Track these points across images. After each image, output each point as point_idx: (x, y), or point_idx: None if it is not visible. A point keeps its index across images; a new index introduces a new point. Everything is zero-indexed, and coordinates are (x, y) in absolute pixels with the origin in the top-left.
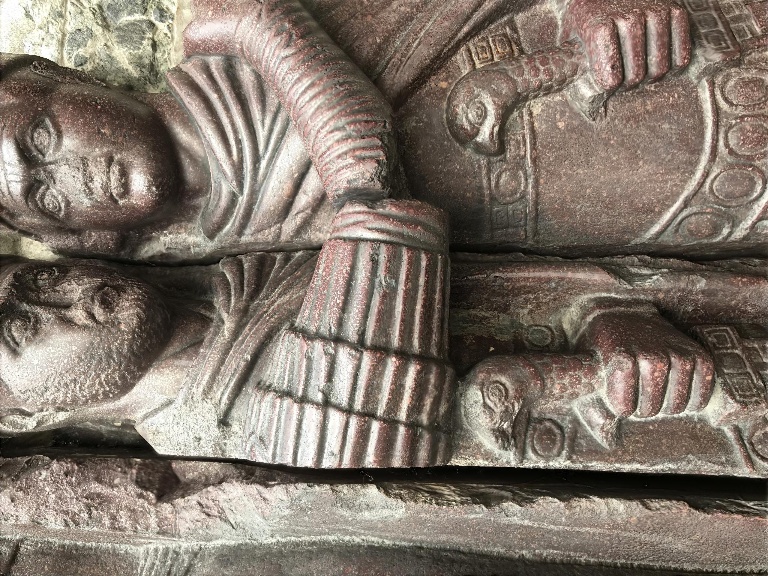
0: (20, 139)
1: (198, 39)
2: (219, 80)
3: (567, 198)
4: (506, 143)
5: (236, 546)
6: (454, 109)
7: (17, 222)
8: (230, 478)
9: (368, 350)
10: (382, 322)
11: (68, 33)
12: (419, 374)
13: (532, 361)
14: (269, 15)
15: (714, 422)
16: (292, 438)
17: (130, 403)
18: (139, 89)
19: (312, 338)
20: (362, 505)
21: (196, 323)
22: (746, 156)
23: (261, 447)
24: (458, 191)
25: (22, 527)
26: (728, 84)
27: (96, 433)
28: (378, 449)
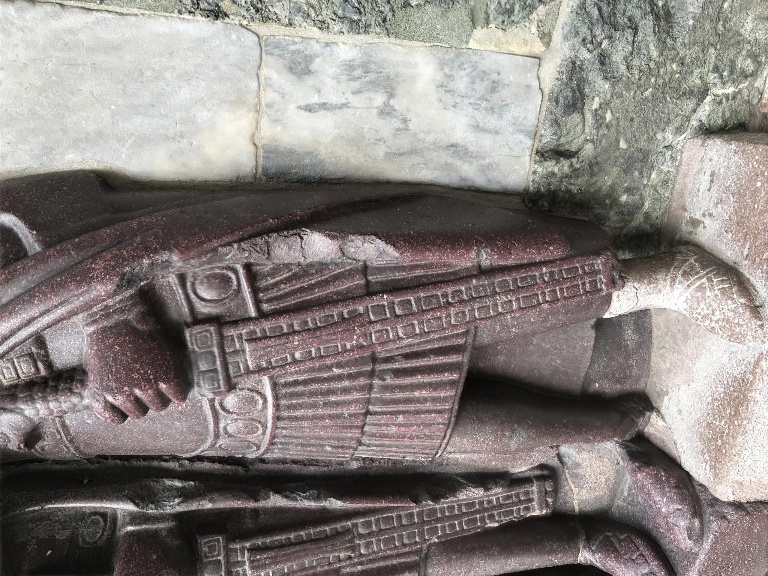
0: None
1: None
2: None
3: (108, 450)
4: (43, 433)
5: None
6: None
7: None
8: None
9: None
10: None
11: None
12: None
13: None
14: None
15: None
16: None
17: None
18: None
19: None
20: None
21: None
22: (242, 437)
23: None
24: (10, 451)
25: None
26: (227, 398)
27: None
28: None
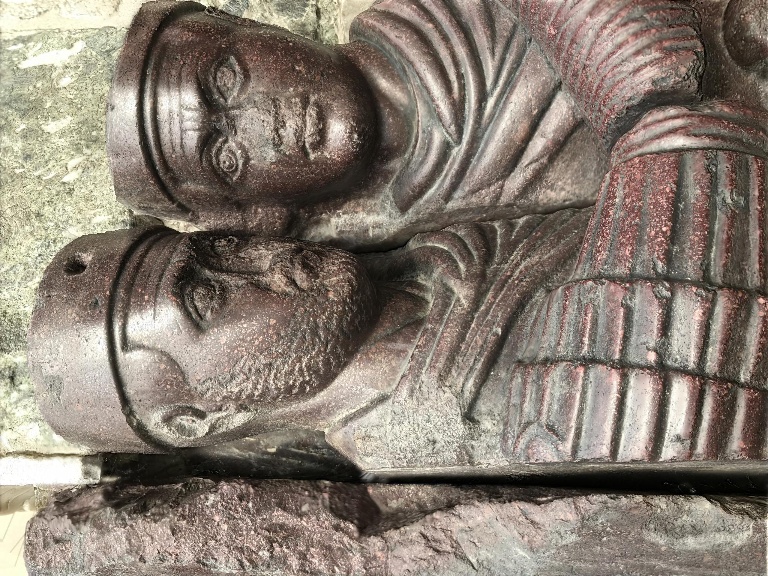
0: (202, 78)
1: None
2: (434, 8)
3: None
4: None
5: None
6: (746, 17)
7: (179, 190)
8: (465, 499)
9: (724, 288)
10: (734, 253)
11: (220, 6)
12: None
13: None
14: None
15: None
16: (610, 420)
17: (327, 402)
18: None
19: (629, 280)
20: (685, 526)
21: (406, 301)
22: None
23: (550, 439)
24: None
25: (180, 571)
26: None
27: (244, 462)
28: (748, 430)
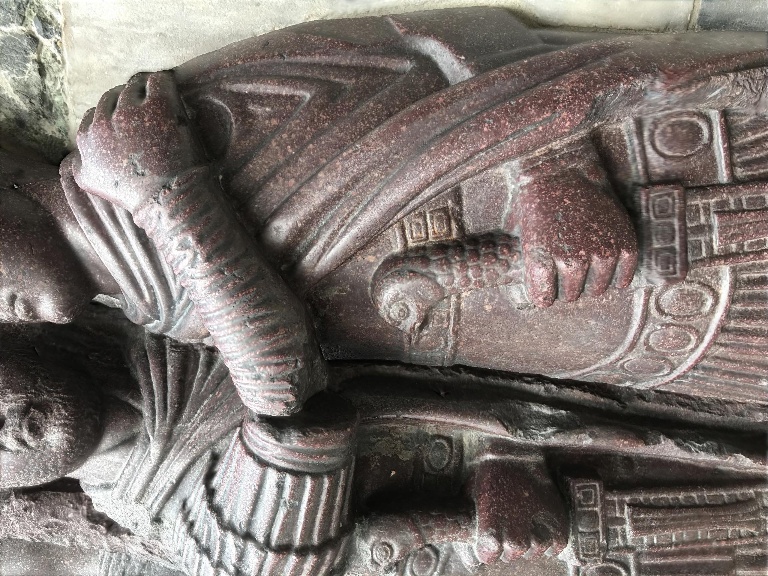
0: None
1: (91, 193)
2: (122, 223)
3: (485, 354)
4: (430, 317)
5: (175, 572)
6: (377, 303)
7: None
8: None
9: (272, 552)
10: (285, 530)
11: None
12: (316, 562)
13: (418, 525)
14: (169, 223)
15: (561, 557)
16: None
17: (72, 477)
18: (32, 125)
19: (225, 528)
20: None
21: (125, 419)
22: (662, 352)
23: (186, 570)
24: (379, 340)
25: None
26: (666, 292)
27: None
28: None
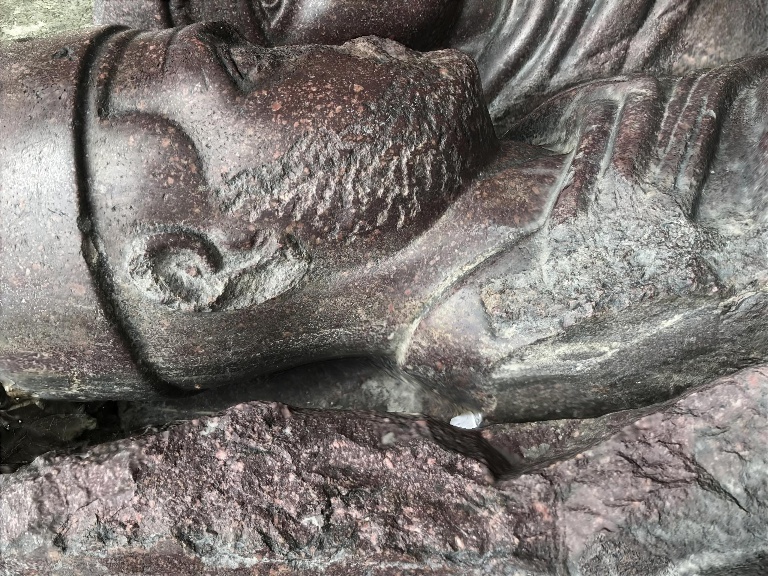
0: None
1: None
2: None
3: None
4: None
5: (760, 561)
6: None
7: None
8: None
9: None
10: None
11: None
12: None
13: None
14: None
15: None
16: None
17: (427, 255)
18: None
19: None
20: None
21: None
22: None
23: None
24: None
25: (133, 571)
26: None
27: None
28: None
